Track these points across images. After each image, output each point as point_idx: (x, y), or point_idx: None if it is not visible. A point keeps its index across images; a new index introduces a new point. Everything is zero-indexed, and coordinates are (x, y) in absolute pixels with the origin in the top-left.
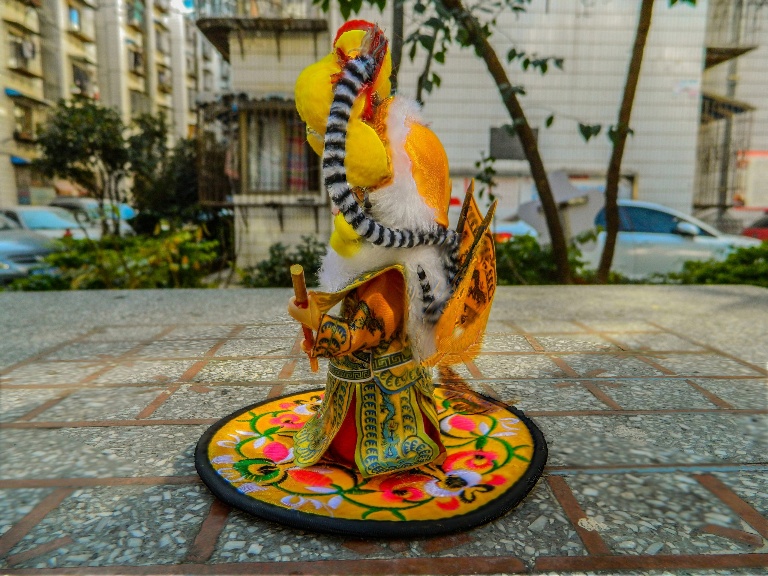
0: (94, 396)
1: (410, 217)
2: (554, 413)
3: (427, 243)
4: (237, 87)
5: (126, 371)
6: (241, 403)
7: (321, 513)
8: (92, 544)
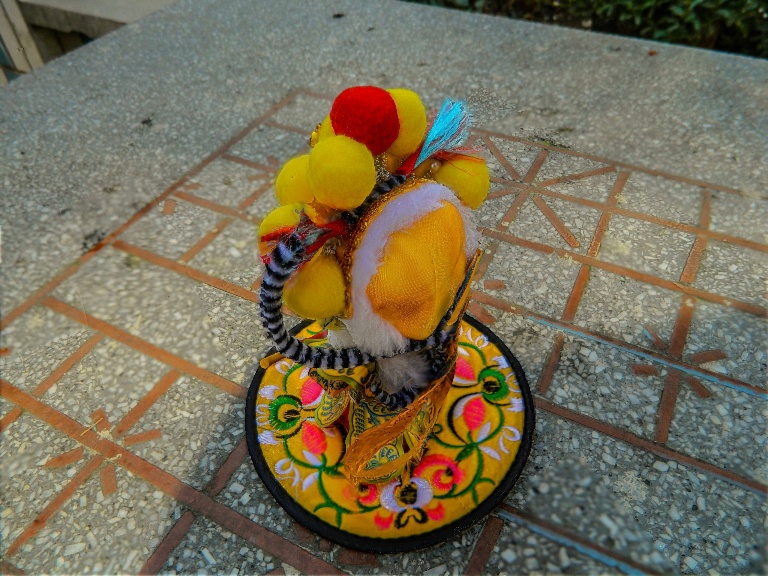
0: (239, 237)
1: (370, 346)
2: (585, 421)
3: None
4: None
5: None
6: None
7: (291, 493)
8: (168, 445)
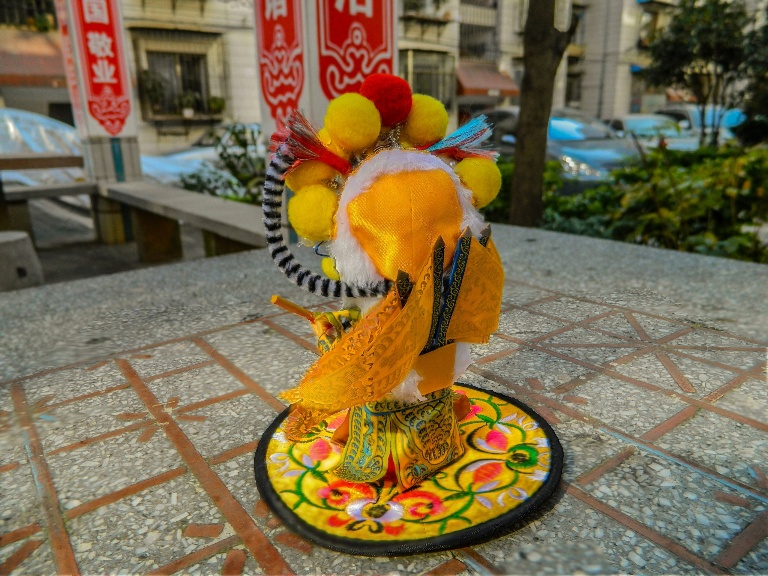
0: None
1: (347, 272)
2: (622, 518)
3: (376, 296)
4: (583, 50)
5: None
6: None
7: (270, 474)
8: None
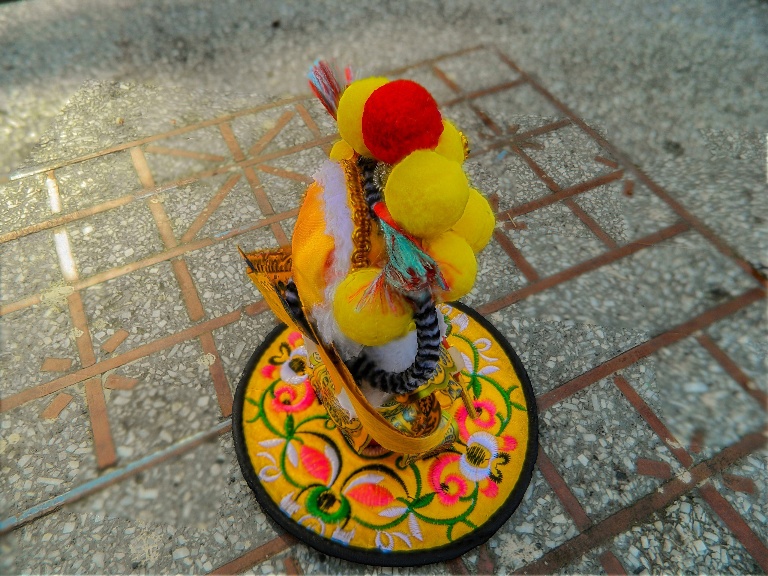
0: (726, 404)
1: None
2: (226, 570)
3: None
4: None
5: None
6: (570, 447)
7: None
8: None
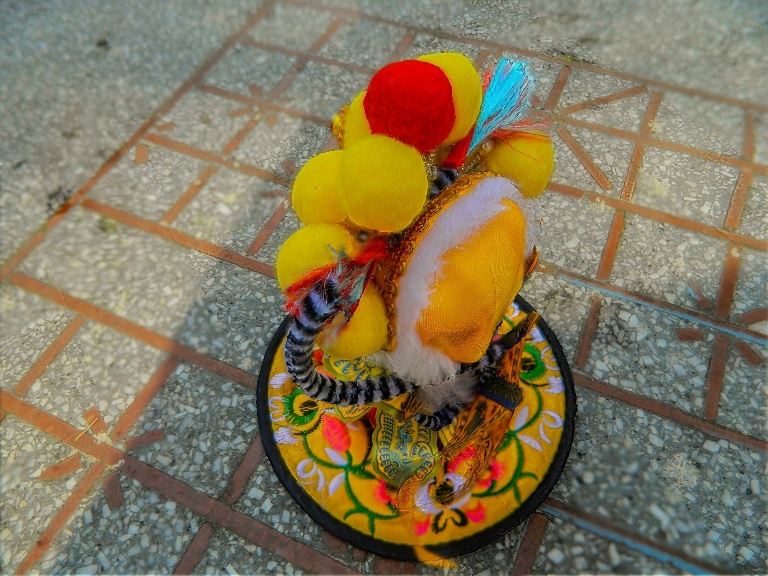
0: (226, 190)
1: (415, 377)
2: (628, 398)
3: None
4: None
5: (264, 138)
6: None
7: (317, 500)
8: (174, 447)
